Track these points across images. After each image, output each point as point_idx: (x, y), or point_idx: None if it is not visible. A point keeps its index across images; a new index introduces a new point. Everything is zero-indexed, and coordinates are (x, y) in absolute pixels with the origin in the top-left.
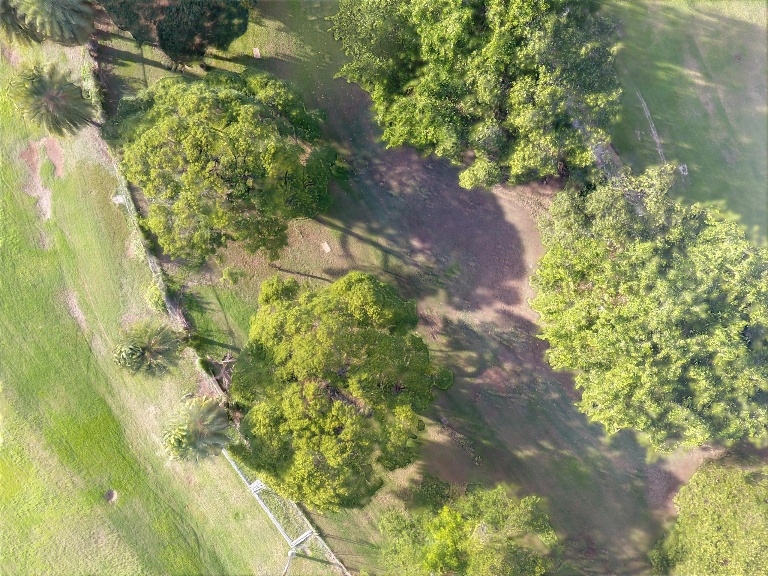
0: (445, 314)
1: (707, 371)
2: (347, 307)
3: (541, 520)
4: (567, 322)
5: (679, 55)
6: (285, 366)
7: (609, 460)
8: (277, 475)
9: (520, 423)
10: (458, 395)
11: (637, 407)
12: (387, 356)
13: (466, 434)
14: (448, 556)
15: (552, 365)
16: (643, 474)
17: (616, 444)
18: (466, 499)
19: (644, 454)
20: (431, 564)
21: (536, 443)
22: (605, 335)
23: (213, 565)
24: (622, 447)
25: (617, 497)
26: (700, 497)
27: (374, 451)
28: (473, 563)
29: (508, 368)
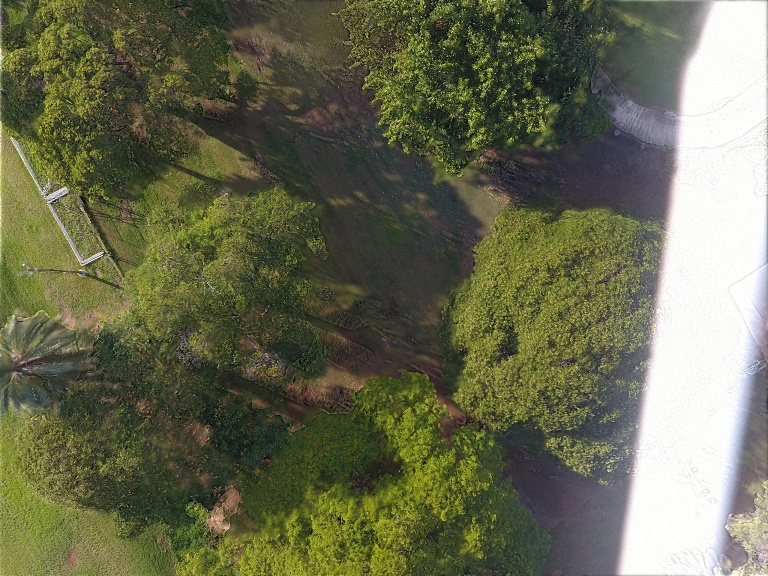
0: (274, 45)
1: (478, 33)
2: None
3: (309, 221)
4: (362, 6)
5: None
6: (46, 6)
7: (425, 220)
8: (35, 136)
9: (338, 170)
10: (277, 133)
11: (419, 99)
12: (170, 28)
13: (279, 174)
14: (199, 237)
15: (364, 88)
16: (458, 239)
17: (434, 203)
18: (240, 200)
19: (462, 216)
20: (178, 239)
21: (352, 193)
22: (386, 1)
23: (1, 276)
24: (440, 207)
25: (429, 261)
26: (495, 239)
27: (135, 116)
28: (217, 237)
29: (333, 110)
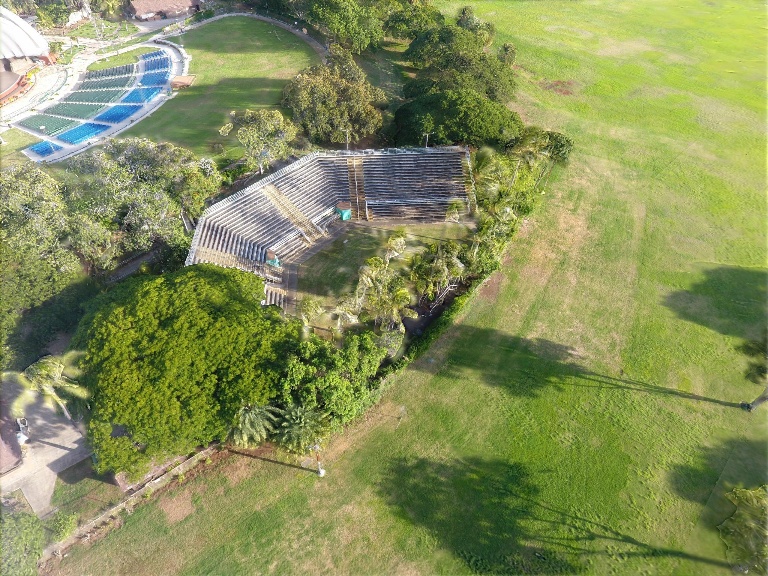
0: None
1: None
2: (376, 8)
3: None
4: None
5: (264, 46)
6: None
7: None
8: None
9: None
10: None
11: None
12: None
13: None
14: None
15: None
16: None
17: None
18: None
19: None
20: None
21: None
22: None
23: None
24: None
25: None
26: None
27: None
28: None
29: None
